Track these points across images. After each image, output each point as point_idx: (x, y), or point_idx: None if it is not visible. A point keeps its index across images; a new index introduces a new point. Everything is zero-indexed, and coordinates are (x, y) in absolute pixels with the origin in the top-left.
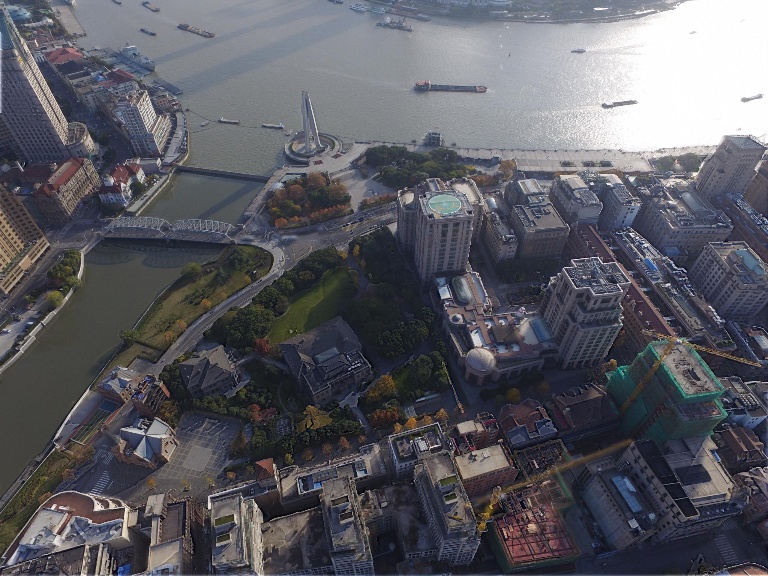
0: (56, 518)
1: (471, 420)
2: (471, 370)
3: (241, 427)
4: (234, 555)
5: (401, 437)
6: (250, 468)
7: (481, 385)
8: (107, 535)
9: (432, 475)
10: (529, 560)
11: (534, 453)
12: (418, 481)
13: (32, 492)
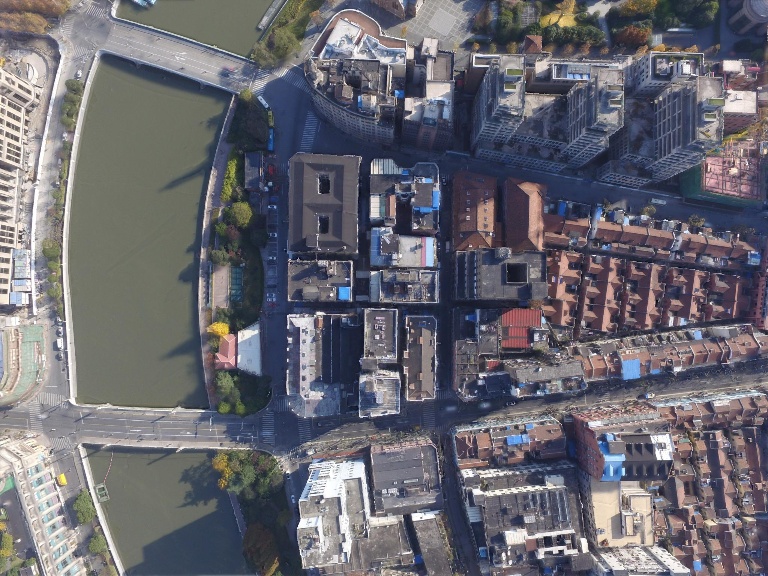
0: (353, 30)
1: (739, 61)
2: (749, 11)
3: (488, 2)
4: (516, 103)
5: (663, 56)
6: (494, 46)
7: (742, 34)
8: (393, 59)
9: (700, 94)
10: (718, 192)
11: (767, 115)
12: (669, 99)
13: (298, 7)
